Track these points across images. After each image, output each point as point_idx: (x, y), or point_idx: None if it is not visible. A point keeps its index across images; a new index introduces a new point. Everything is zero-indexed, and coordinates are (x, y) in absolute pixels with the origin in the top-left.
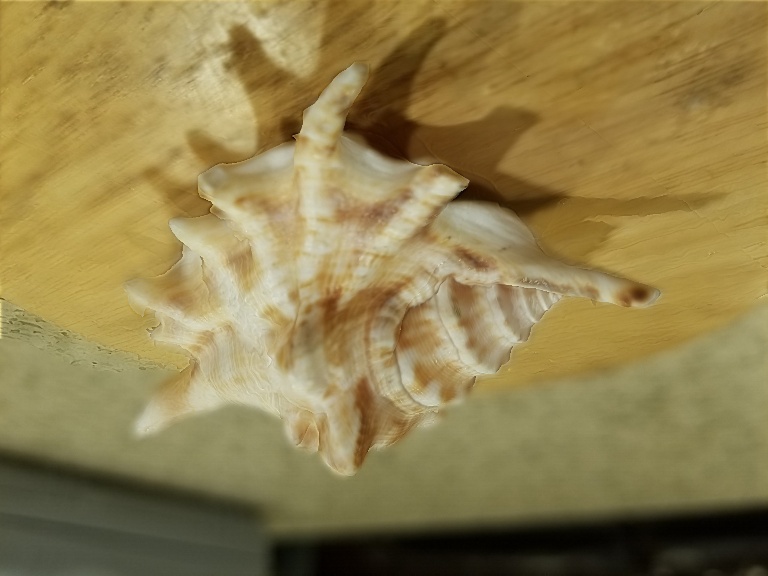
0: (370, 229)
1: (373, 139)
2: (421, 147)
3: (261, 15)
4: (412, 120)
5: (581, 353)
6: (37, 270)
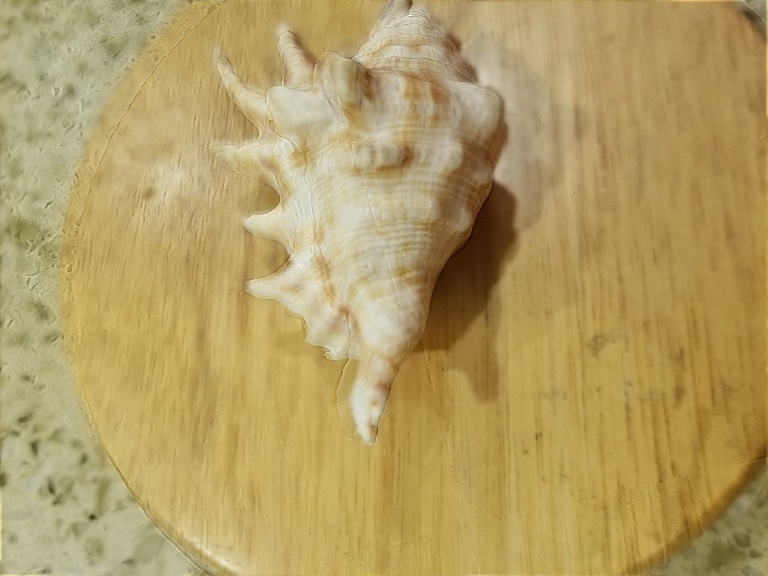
0: None
1: None
2: None
3: (223, 132)
4: None
5: (747, 100)
6: (258, 477)
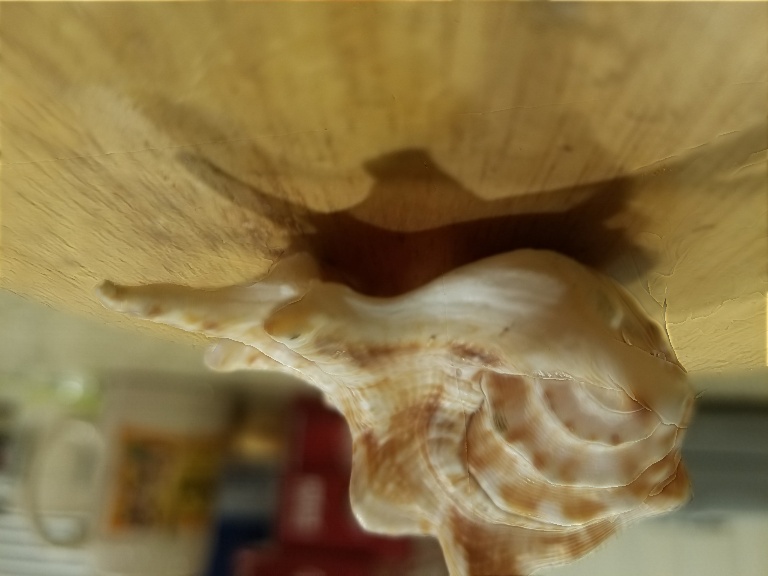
0: None
1: (298, 262)
2: (366, 231)
3: (129, 224)
4: (332, 212)
5: None
6: None
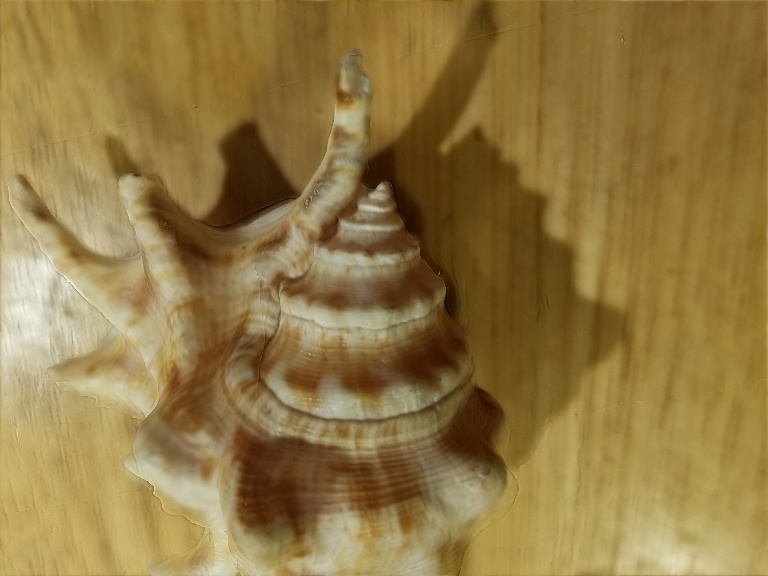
0: (154, 291)
1: None
2: None
3: None
4: None
5: None
6: None
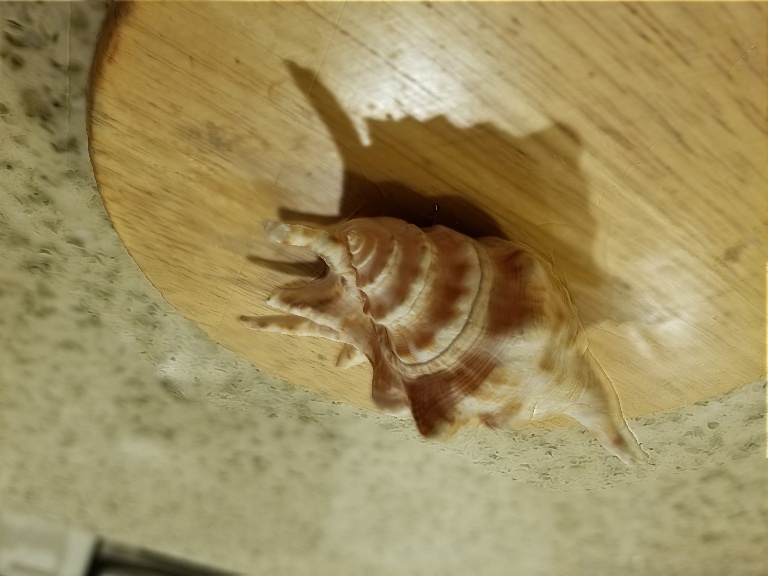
0: None
1: None
2: None
3: None
4: (319, 259)
5: None
6: None
